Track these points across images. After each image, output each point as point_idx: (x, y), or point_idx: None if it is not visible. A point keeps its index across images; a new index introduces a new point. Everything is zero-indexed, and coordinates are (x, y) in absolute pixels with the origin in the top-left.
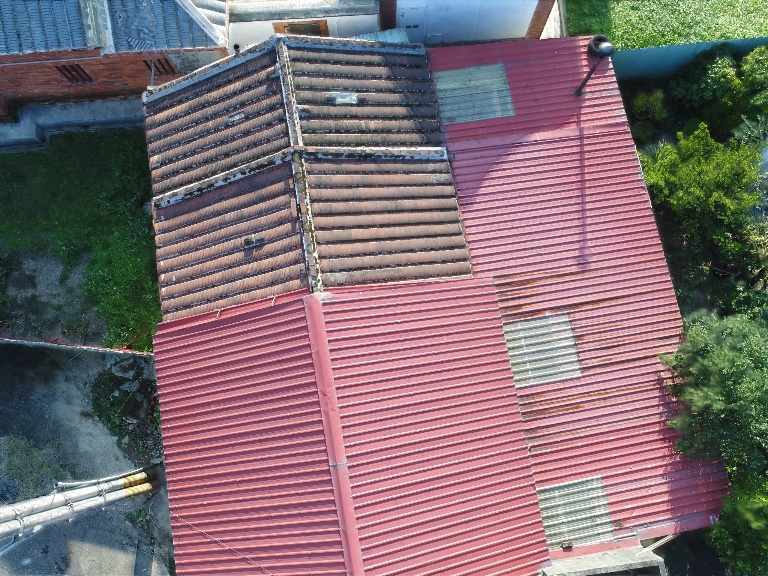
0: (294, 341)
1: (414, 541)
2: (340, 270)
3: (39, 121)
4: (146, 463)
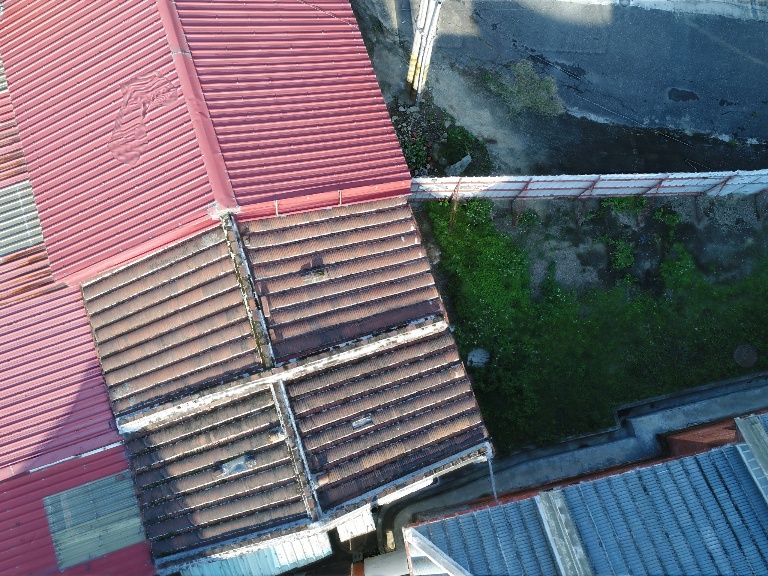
0: (245, 166)
1: (109, 7)
2: (209, 249)
3: (634, 441)
4: (423, 106)
